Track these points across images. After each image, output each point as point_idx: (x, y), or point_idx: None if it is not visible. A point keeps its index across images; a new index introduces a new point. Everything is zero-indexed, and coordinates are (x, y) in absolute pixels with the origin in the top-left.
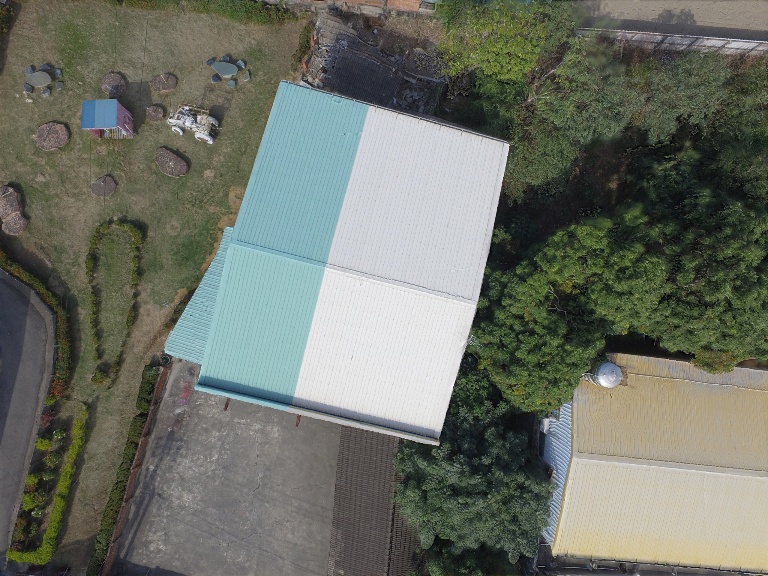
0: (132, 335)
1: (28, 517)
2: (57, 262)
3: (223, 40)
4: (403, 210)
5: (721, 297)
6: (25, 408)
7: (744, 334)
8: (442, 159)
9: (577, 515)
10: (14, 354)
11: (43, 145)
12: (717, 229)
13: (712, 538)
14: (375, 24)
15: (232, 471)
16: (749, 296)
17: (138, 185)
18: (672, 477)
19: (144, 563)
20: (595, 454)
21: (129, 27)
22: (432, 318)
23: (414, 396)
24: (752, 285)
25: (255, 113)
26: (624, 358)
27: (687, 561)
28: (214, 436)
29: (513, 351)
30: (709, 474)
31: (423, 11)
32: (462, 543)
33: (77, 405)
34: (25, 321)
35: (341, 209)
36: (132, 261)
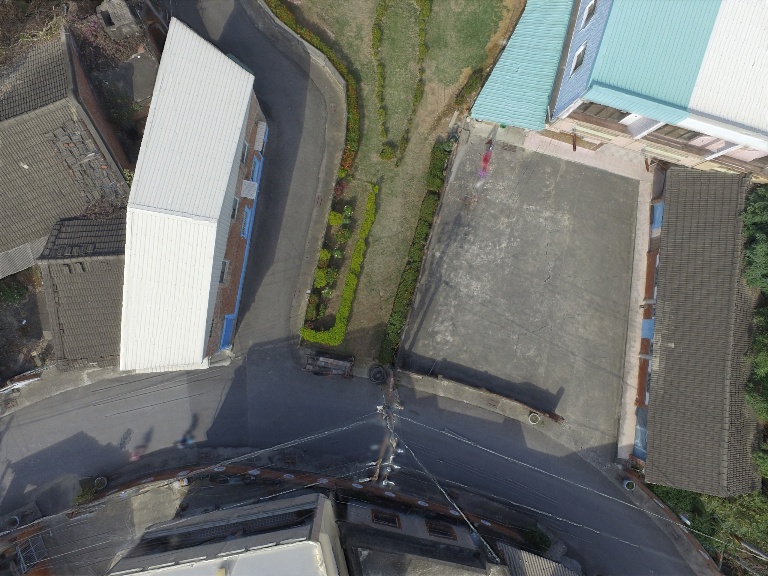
0: (417, 114)
1: None
2: (339, 34)
3: None
4: None
5: None
6: (306, 188)
7: None
8: None
9: None
10: (295, 130)
11: None
12: None
13: None
14: None
15: (522, 260)
16: None
17: None
18: None
19: (430, 355)
20: None
21: None
22: None
23: None
24: None
25: None
26: None
27: None
28: (503, 222)
29: None
30: None
31: None
32: None
33: (361, 185)
34: (305, 96)
35: None
36: (417, 36)
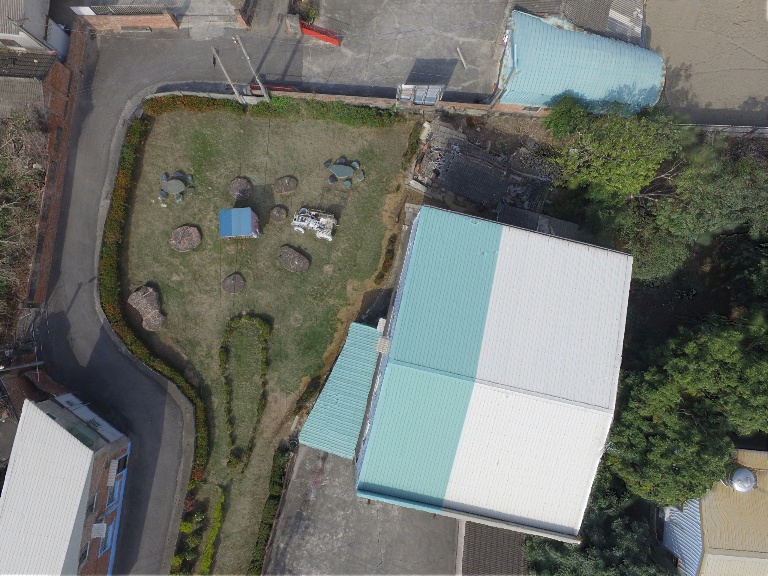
0: (261, 421)
1: None
2: (192, 355)
3: (338, 143)
4: (540, 324)
5: None
6: (165, 491)
7: None
8: (572, 274)
9: None
10: (154, 441)
11: (178, 247)
12: None
13: None
14: (478, 122)
15: (356, 548)
16: None
17: (264, 281)
18: None
19: None
20: (725, 549)
21: (253, 134)
22: (572, 426)
23: (554, 497)
24: None
25: (369, 210)
26: (744, 453)
27: None
28: (339, 515)
29: (642, 451)
30: None
31: (526, 112)
32: None
33: (213, 488)
34: (163, 410)
35: (485, 326)
36: (260, 352)
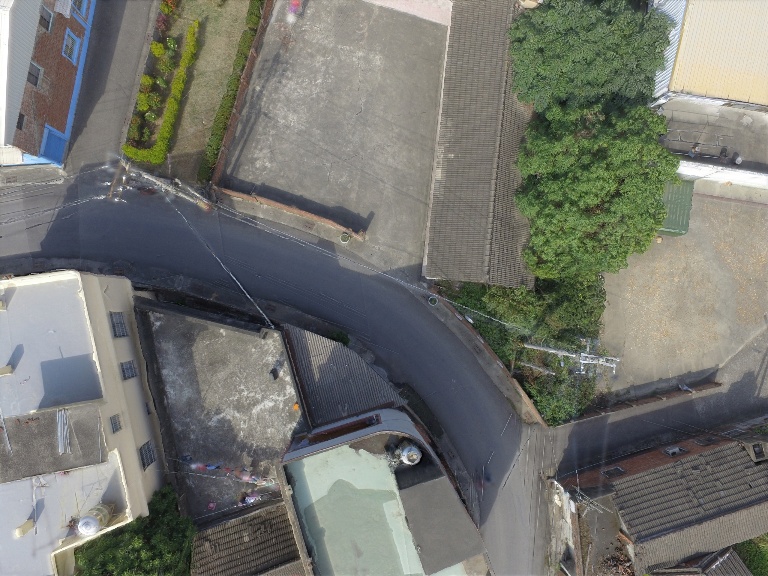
0: None
1: (142, 119)
2: None
3: None
4: None
5: None
6: (136, 25)
7: None
8: None
9: (695, 45)
10: None
11: None
12: None
13: None
14: None
15: (336, 95)
16: None
17: None
18: None
19: (250, 179)
20: None
21: None
22: None
23: None
24: None
25: None
26: None
27: None
28: (318, 61)
29: None
30: None
31: None
32: (579, 90)
33: (187, 23)
34: None
35: None
36: None
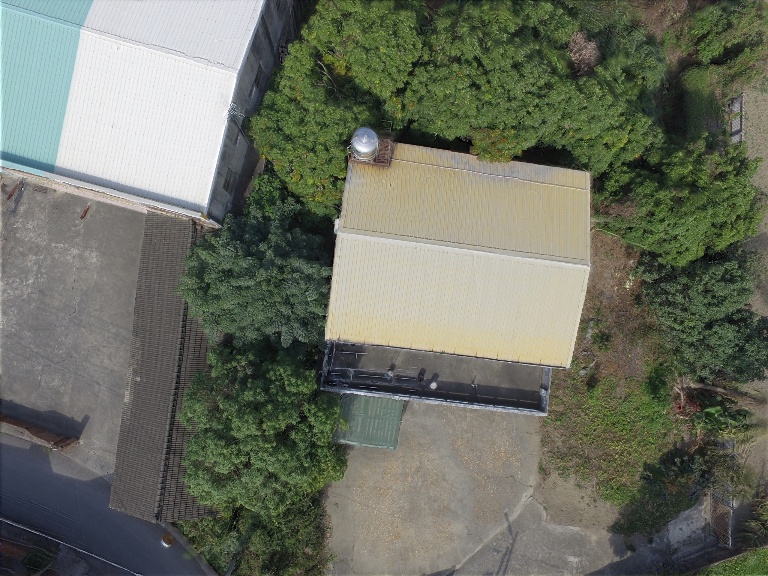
0: None
1: None
2: None
3: None
4: None
5: (470, 55)
6: None
7: (497, 97)
8: None
9: (346, 295)
10: None
11: None
12: (484, 4)
13: (487, 325)
14: None
15: (48, 295)
16: (494, 51)
17: None
18: (441, 257)
19: None
20: (361, 230)
21: None
22: (193, 86)
23: (178, 169)
24: (499, 42)
25: None
26: (405, 148)
27: (463, 349)
28: (30, 260)
29: None
30: (478, 254)
31: None
32: (240, 332)
33: None
34: None
35: None
36: None
